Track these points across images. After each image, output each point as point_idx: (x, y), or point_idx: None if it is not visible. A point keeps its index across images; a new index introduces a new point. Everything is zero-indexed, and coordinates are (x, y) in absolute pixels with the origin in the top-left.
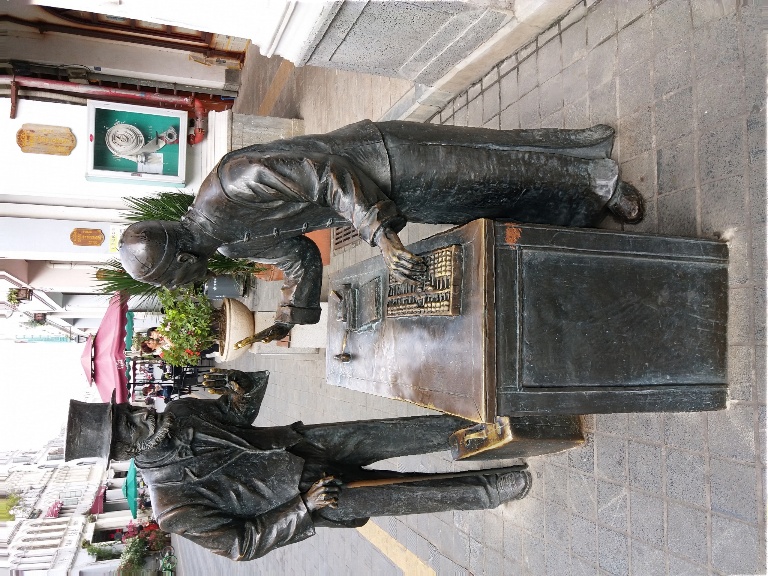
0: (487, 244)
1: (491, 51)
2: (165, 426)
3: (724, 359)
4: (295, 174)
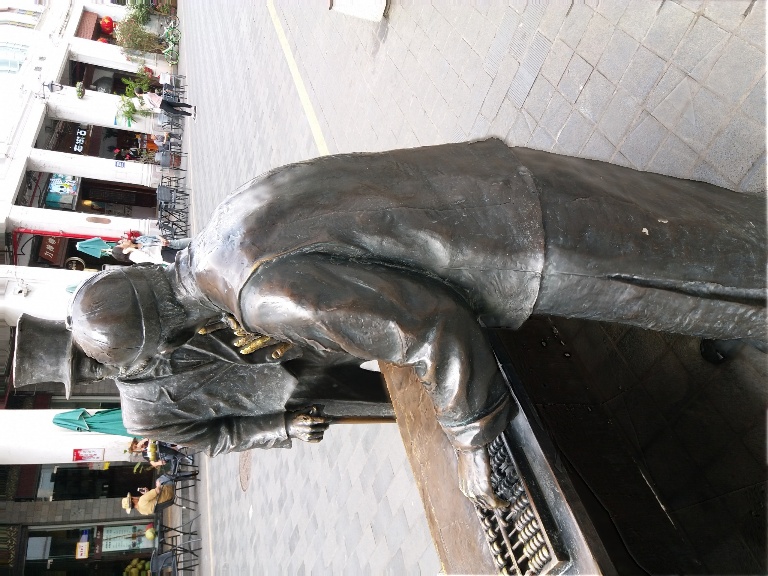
0: None
1: None
2: (139, 366)
3: None
4: (370, 342)
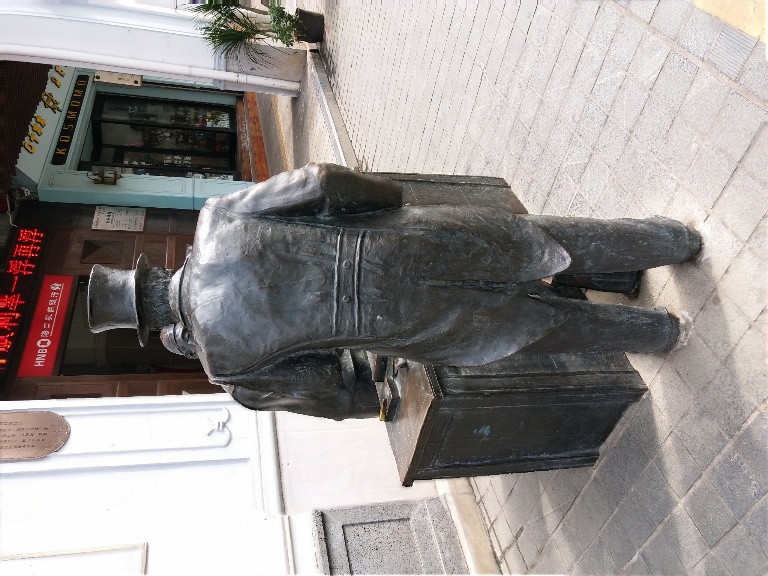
0: None
1: (473, 545)
2: None
3: None
4: None
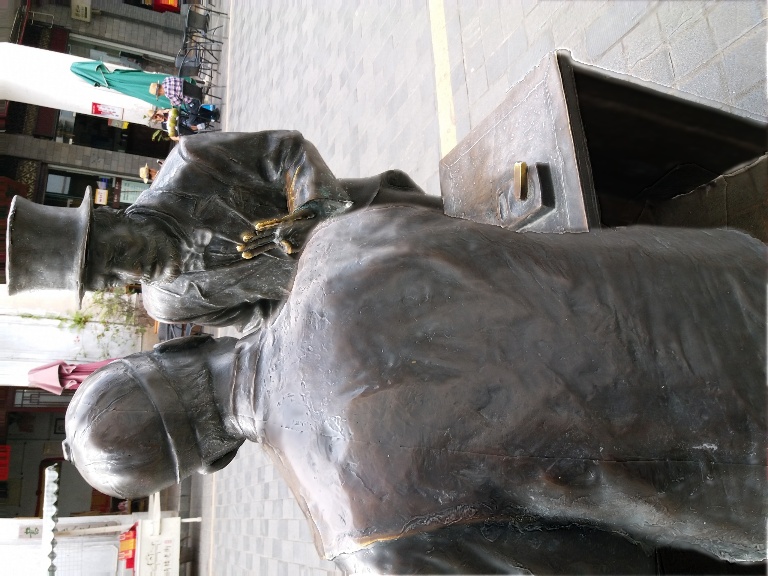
0: None
1: None
2: (166, 281)
3: None
4: None
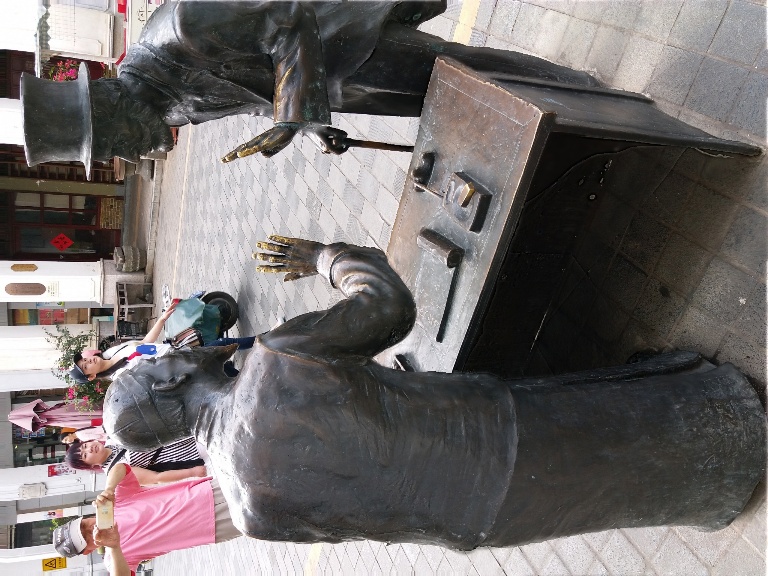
0: None
1: None
2: None
3: None
4: None
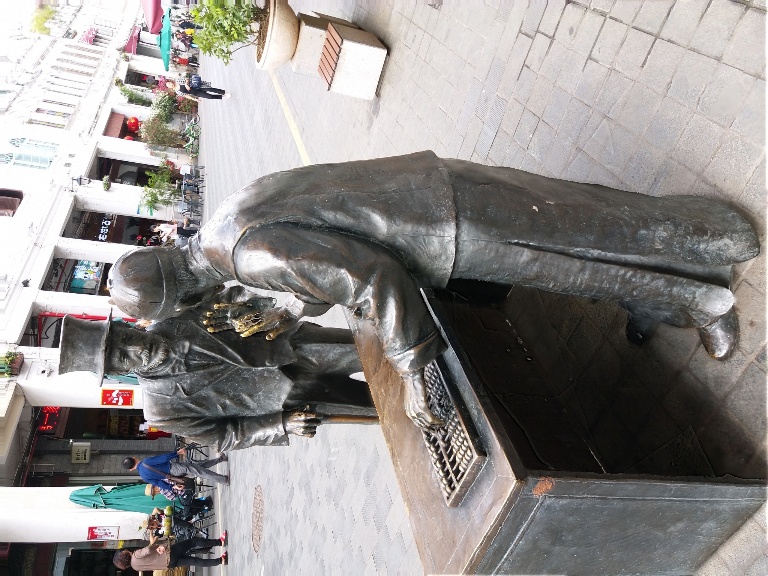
0: (507, 503)
1: None
2: (159, 359)
3: (704, 560)
4: (328, 285)
